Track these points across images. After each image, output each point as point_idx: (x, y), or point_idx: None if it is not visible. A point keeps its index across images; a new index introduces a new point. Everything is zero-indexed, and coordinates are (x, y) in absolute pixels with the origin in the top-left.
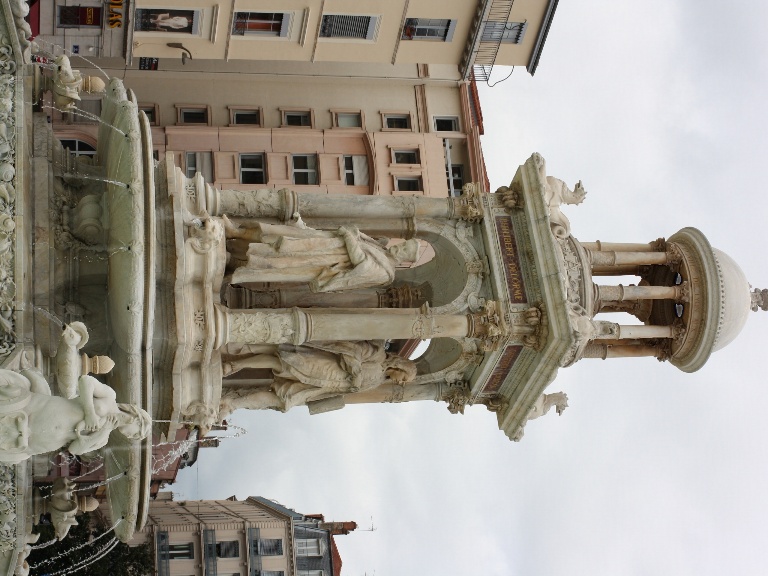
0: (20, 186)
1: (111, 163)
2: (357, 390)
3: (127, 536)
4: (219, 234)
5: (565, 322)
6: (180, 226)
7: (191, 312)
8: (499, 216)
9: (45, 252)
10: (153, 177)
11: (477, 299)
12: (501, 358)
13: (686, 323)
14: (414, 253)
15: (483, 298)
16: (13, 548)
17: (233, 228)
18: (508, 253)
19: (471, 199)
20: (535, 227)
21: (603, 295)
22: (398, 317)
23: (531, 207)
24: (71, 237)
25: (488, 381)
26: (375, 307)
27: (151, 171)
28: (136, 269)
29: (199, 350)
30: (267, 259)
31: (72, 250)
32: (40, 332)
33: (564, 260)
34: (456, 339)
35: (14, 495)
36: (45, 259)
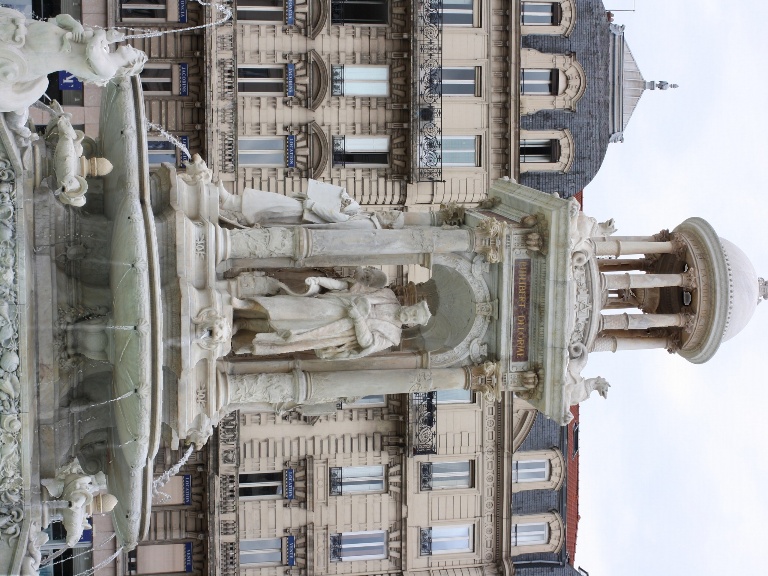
0: (25, 378)
1: (118, 311)
2: None
3: None
4: (226, 337)
5: (559, 402)
6: (187, 333)
7: (193, 392)
8: (519, 259)
9: (50, 393)
10: (161, 367)
11: (480, 346)
12: None
13: (683, 342)
14: (423, 323)
15: (486, 345)
16: None
17: (241, 307)
18: (520, 303)
19: (494, 239)
20: (552, 288)
21: (607, 328)
22: (397, 380)
23: (553, 264)
24: (76, 359)
25: None
26: None
27: (160, 363)
28: (141, 452)
29: None
30: (273, 349)
31: (76, 368)
32: (45, 453)
33: (576, 301)
34: None
35: None
36: (50, 400)
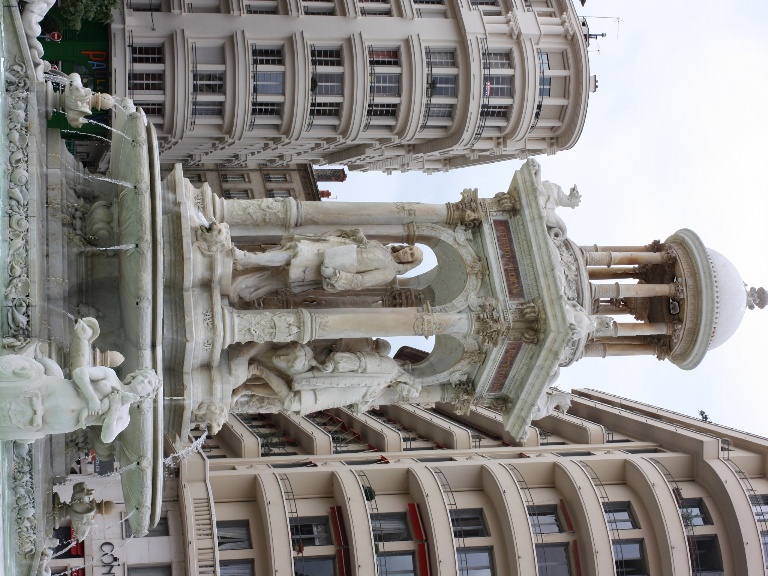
0: None
1: None
2: (365, 246)
3: (141, 174)
4: None
5: None
6: None
7: None
8: None
9: None
10: None
11: None
12: (497, 241)
13: None
14: None
15: None
16: (25, 262)
17: None
18: None
19: None
20: None
21: None
22: None
23: None
24: None
25: (505, 280)
26: (380, 300)
27: None
28: None
29: (200, 207)
30: None
31: None
32: None
33: None
34: (449, 243)
35: (27, 136)
36: None
